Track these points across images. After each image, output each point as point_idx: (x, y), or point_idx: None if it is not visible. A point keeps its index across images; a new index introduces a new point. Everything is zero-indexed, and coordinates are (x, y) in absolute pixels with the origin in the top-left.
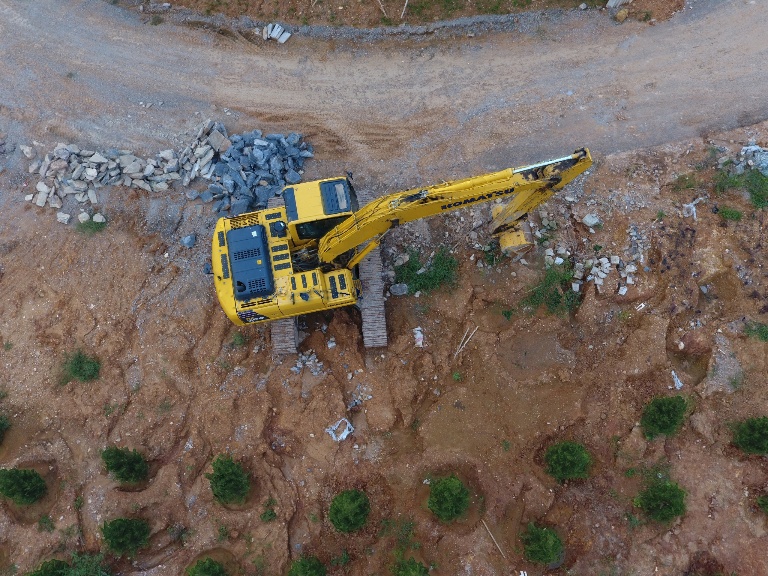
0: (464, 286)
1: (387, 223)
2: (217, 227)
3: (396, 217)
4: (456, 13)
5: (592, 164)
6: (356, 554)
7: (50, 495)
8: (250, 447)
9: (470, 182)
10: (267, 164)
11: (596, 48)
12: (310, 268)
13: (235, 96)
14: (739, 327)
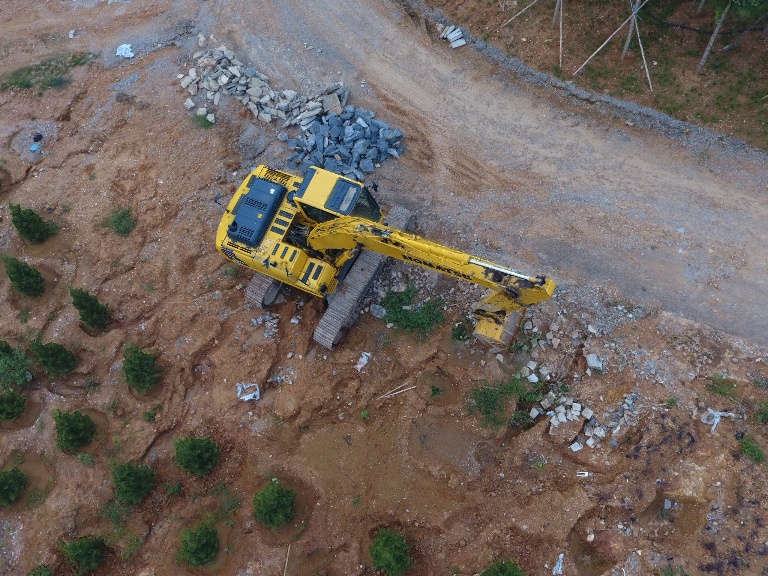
0: (432, 344)
1: (355, 242)
2: (255, 170)
3: (361, 241)
4: (629, 95)
5: (642, 310)
6: (186, 493)
7: (42, 298)
8: (179, 357)
9: (428, 247)
10: (352, 143)
11: (750, 201)
12: (303, 246)
13: (380, 74)
14: (662, 563)
